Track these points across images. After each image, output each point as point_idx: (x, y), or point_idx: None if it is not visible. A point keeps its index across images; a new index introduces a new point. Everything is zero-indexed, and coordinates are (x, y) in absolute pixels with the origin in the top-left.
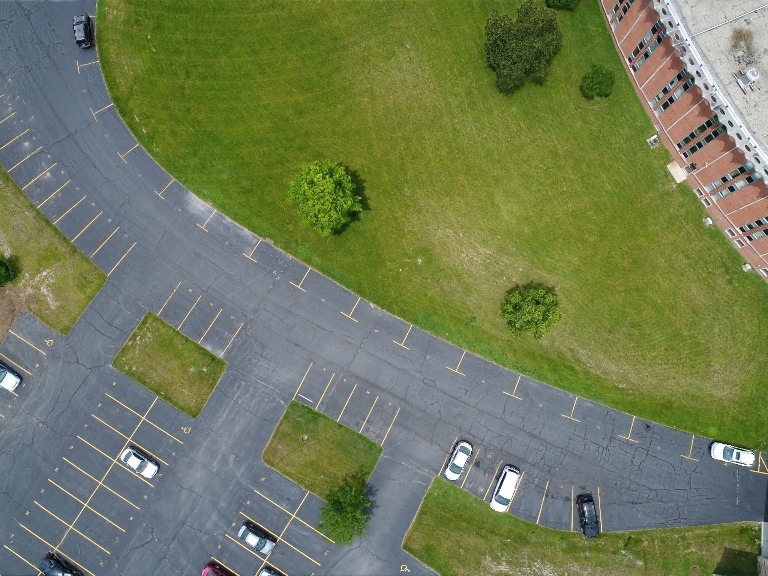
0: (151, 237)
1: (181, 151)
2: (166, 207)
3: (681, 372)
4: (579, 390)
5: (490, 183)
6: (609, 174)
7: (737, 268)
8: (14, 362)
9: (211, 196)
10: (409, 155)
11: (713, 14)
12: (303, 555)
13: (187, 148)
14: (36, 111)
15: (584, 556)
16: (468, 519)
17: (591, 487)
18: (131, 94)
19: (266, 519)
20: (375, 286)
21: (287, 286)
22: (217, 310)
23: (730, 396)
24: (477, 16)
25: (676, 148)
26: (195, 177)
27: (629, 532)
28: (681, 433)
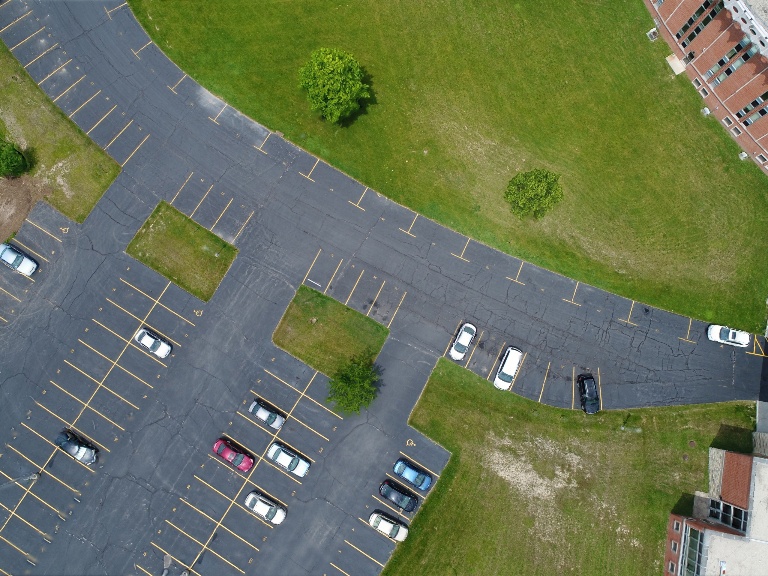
0: (164, 130)
1: (193, 48)
2: (179, 101)
3: (679, 257)
4: (580, 276)
5: (494, 77)
6: (610, 67)
7: (734, 156)
8: (31, 249)
9: (222, 91)
10: (415, 51)
11: None
12: (312, 431)
13: (199, 45)
14: (52, 10)
15: (585, 432)
16: (472, 397)
17: (591, 367)
18: None
19: (276, 397)
20: (382, 177)
21: (296, 176)
22: (228, 199)
23: (726, 280)
24: None
25: (675, 39)
26: (207, 73)
27: (628, 410)
28: (679, 317)
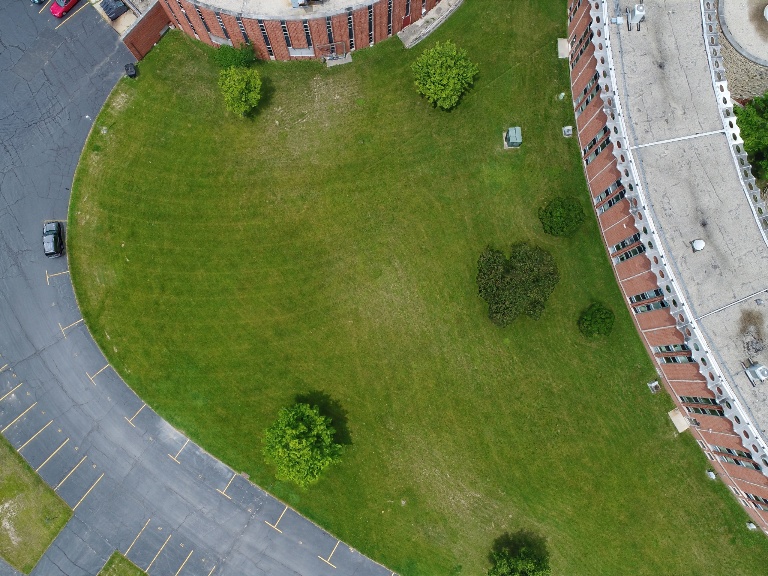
0: (120, 468)
1: (154, 373)
2: (136, 435)
3: None
4: None
5: (480, 420)
6: (606, 418)
7: (741, 526)
8: None
9: (184, 424)
10: (395, 385)
11: (721, 293)
12: None
13: (160, 370)
14: (2, 325)
15: None
16: None
17: None
18: (102, 309)
19: None
20: (355, 528)
21: (262, 526)
22: (188, 551)
23: None
24: (470, 237)
25: (678, 399)
26: (168, 403)
27: None
28: None
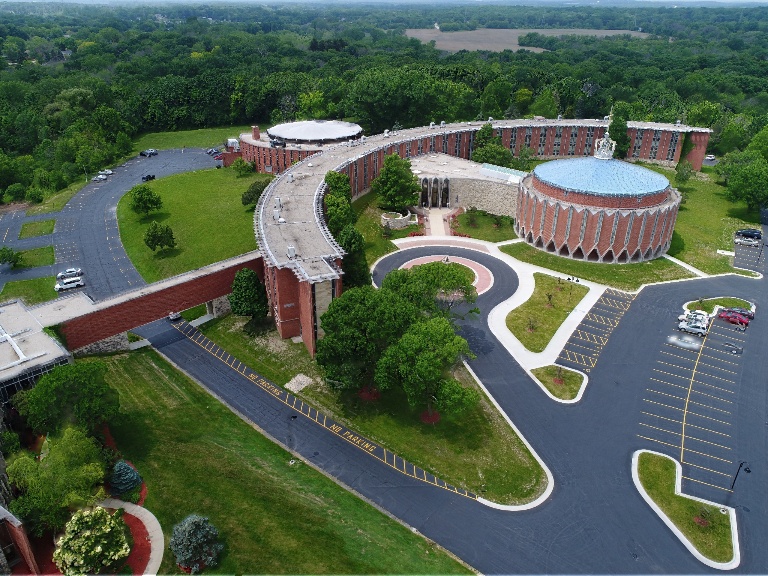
0: None
1: None
2: None
3: None
4: (147, 278)
5: None
6: None
7: None
8: None
9: None
10: None
11: None
12: None
13: None
14: None
15: None
16: None
17: None
18: None
19: None
20: None
21: None
22: None
23: None
24: None
25: None
26: None
27: None
28: None
